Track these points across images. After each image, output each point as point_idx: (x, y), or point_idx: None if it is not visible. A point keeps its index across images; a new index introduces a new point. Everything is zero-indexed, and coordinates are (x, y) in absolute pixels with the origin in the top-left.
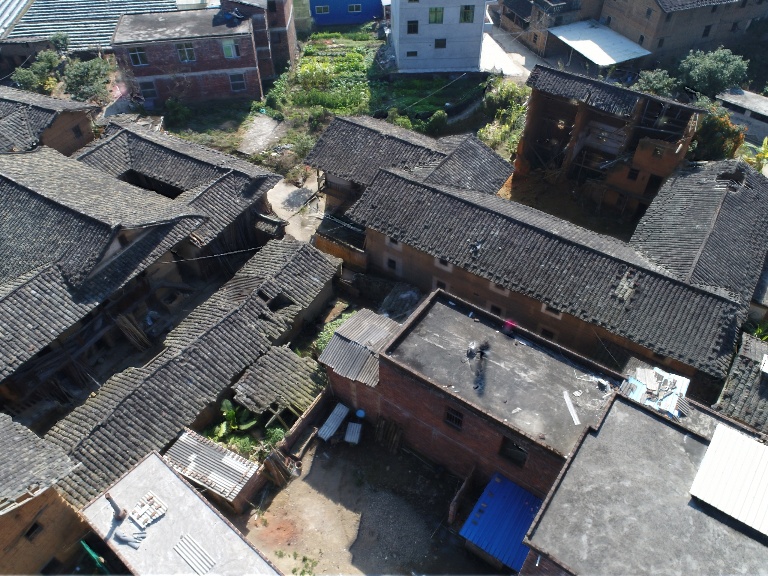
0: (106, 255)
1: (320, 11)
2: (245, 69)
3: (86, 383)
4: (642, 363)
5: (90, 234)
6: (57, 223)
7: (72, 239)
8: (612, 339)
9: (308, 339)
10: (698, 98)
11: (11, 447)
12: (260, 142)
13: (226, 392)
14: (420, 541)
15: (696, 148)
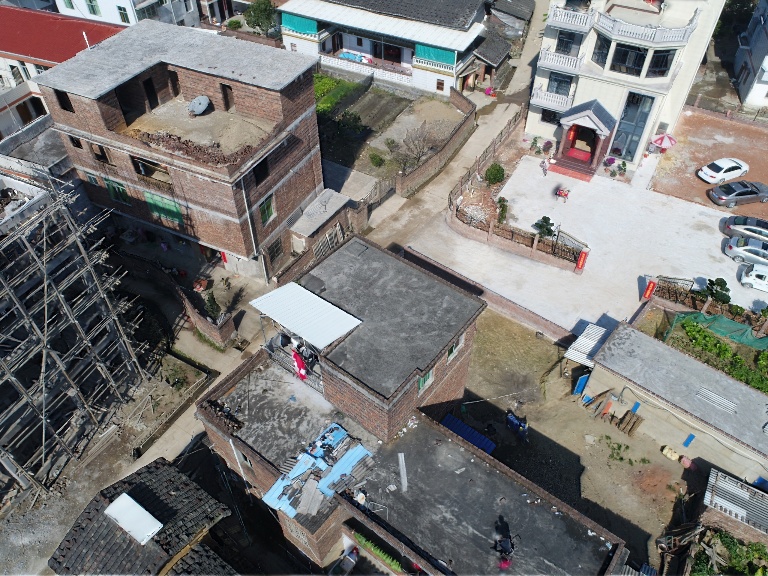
0: None
1: None
2: None
3: None
4: (305, 524)
5: None
6: None
7: None
8: None
9: None
10: None
11: None
12: None
13: None
14: (523, 472)
15: None
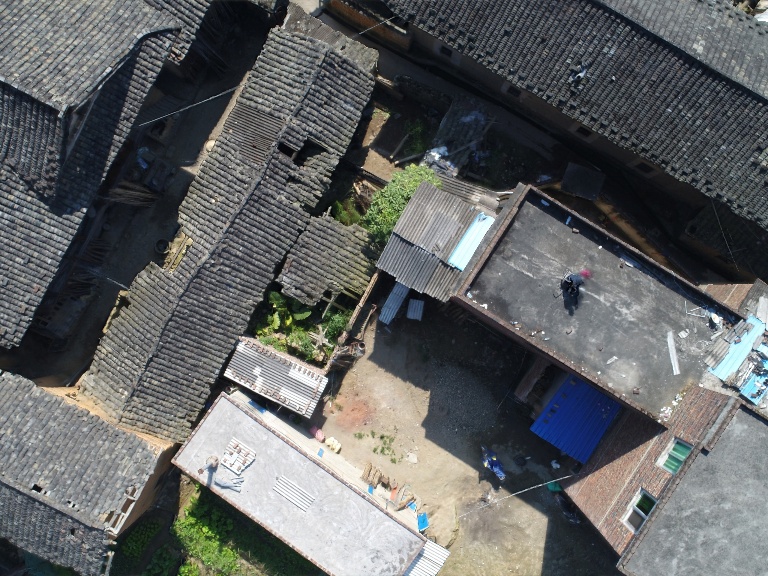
0: None
1: None
2: None
3: (102, 258)
4: (767, 288)
5: (30, 116)
6: None
7: (7, 121)
8: None
9: (346, 177)
10: None
11: (85, 443)
12: None
13: None
14: (487, 413)
15: None
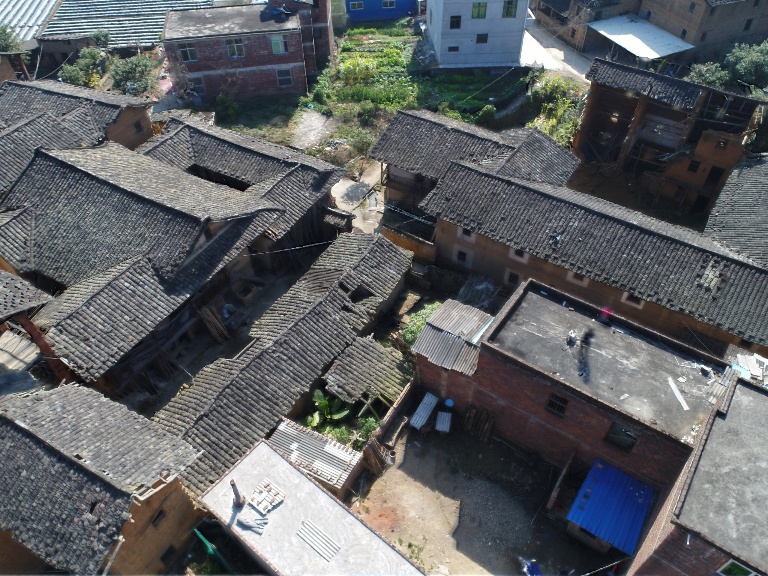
0: None
1: (354, 7)
2: (292, 65)
3: (171, 375)
4: (741, 350)
5: (178, 227)
6: (142, 216)
7: (159, 232)
8: (696, 328)
9: (385, 330)
10: (752, 91)
11: (134, 435)
12: (312, 137)
13: (315, 382)
14: (521, 527)
15: (754, 140)
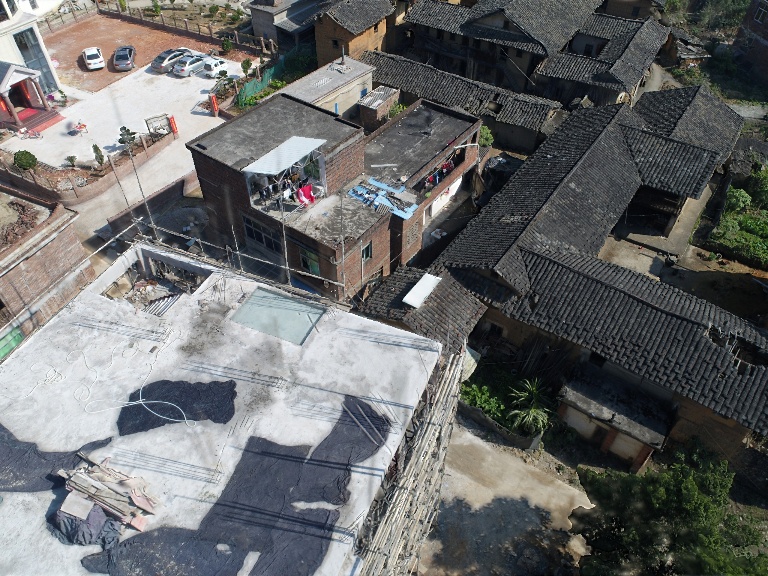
0: (493, 24)
1: None
2: None
3: None
4: (422, 200)
5: None
6: (509, 1)
7: None
8: None
9: None
10: None
11: None
12: None
13: None
14: None
15: None
